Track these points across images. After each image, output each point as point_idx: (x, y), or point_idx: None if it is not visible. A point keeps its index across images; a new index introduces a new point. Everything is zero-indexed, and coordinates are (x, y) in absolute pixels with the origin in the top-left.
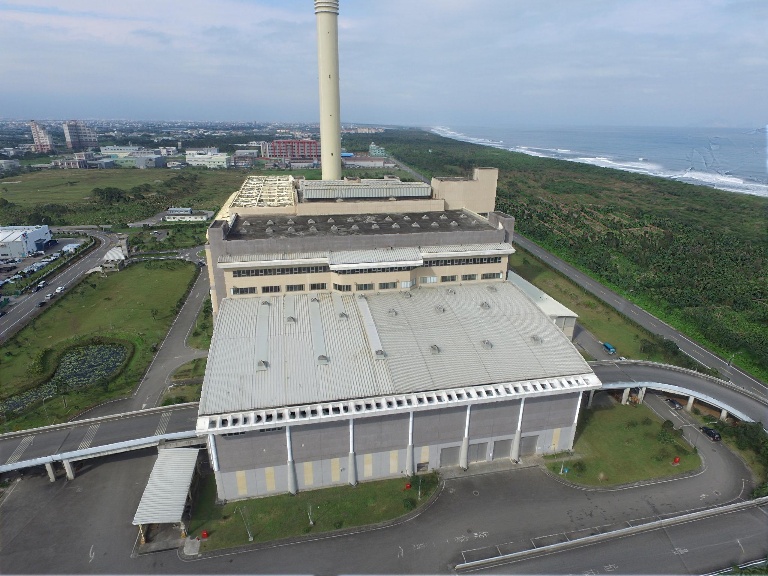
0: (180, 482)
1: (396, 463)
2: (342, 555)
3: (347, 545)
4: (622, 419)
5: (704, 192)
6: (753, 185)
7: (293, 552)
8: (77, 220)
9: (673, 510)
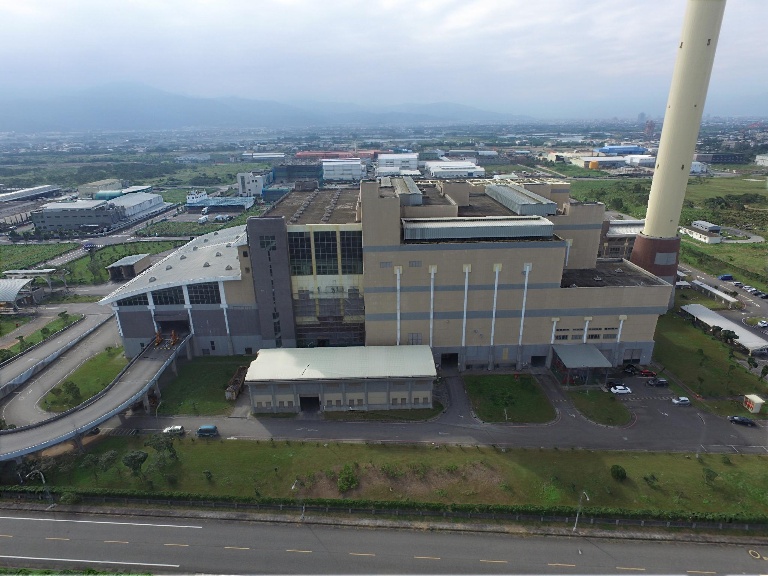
0: None
1: None
2: None
3: None
4: None
5: None
6: None
7: None
8: (637, 211)
9: (45, 375)
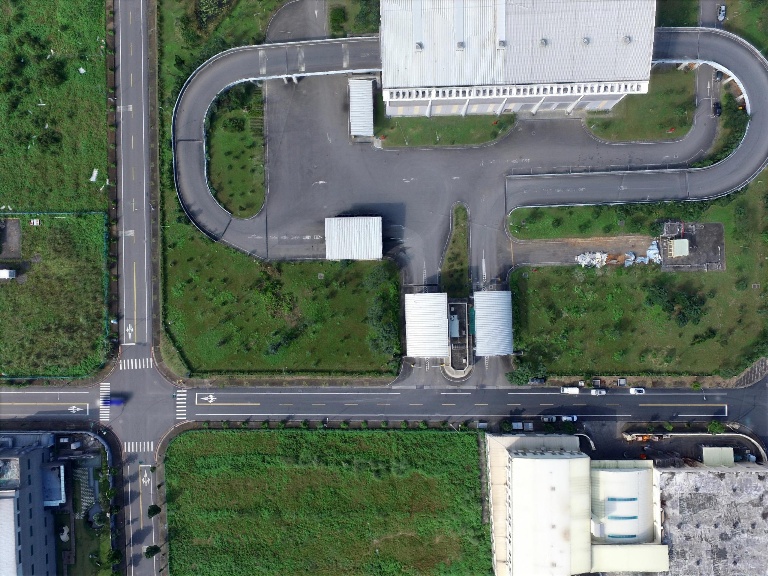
0: (367, 108)
1: (492, 108)
2: (452, 160)
3: (455, 155)
4: (665, 86)
5: None
6: None
7: (428, 154)
8: None
9: (640, 163)
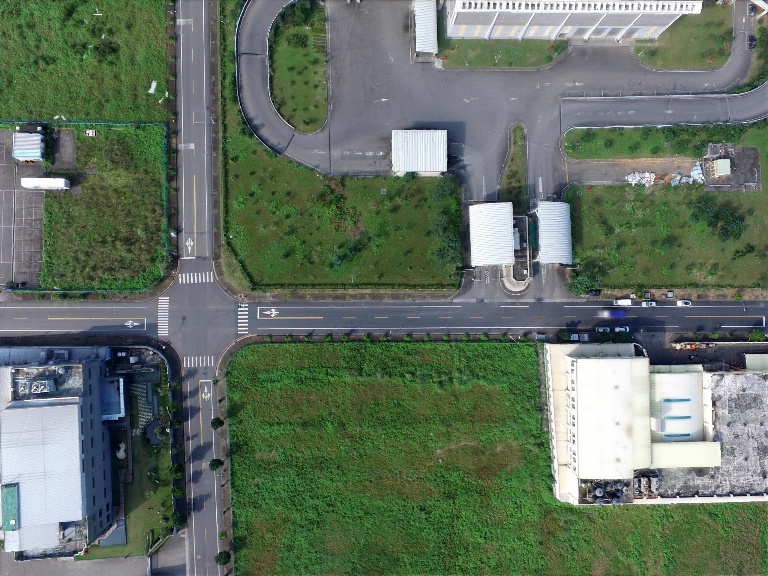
0: (432, 26)
1: (549, 32)
2: (510, 82)
3: (513, 77)
4: (705, 18)
5: None
6: None
7: (487, 76)
8: None
9: (684, 89)
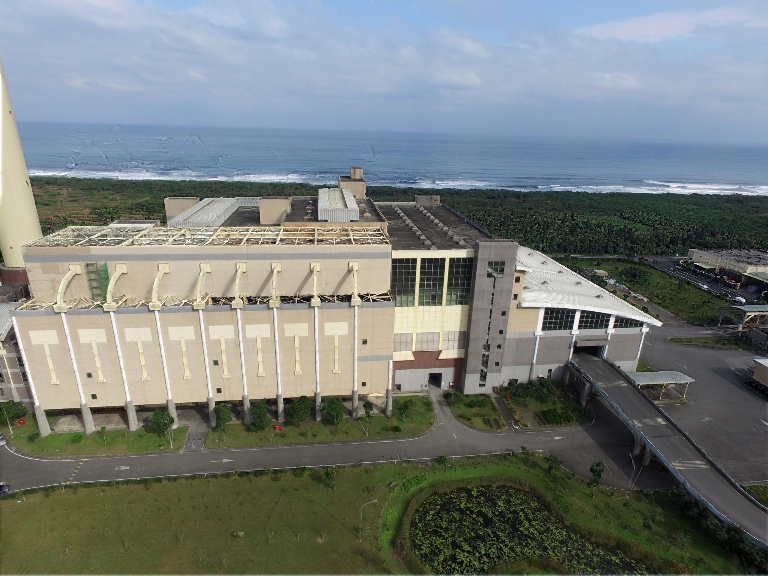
0: None
1: None
2: None
3: None
4: None
5: (127, 183)
6: (156, 172)
7: None
8: None
9: None
